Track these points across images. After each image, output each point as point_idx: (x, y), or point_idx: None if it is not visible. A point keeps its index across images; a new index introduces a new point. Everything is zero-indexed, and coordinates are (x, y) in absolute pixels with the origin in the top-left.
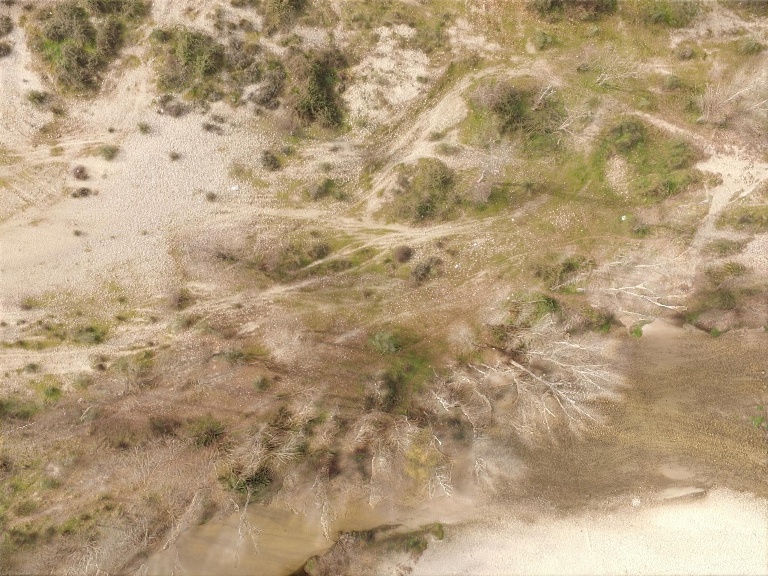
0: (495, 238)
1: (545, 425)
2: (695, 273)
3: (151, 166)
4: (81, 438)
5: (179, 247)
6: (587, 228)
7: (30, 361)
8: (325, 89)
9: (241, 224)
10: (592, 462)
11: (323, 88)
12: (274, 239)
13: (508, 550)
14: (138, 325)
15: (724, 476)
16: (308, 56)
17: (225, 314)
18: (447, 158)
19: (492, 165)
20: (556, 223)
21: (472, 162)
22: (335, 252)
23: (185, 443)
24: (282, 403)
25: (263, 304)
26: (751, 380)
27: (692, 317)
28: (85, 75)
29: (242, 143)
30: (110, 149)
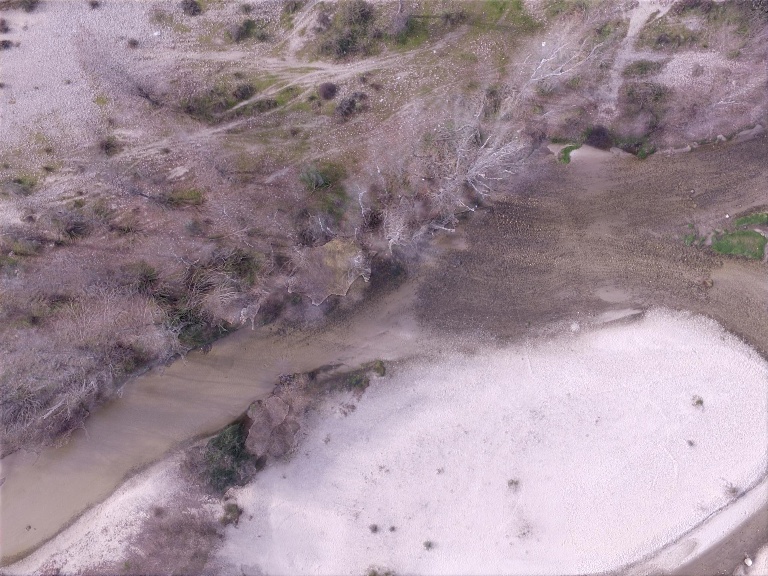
0: (418, 71)
1: (480, 256)
2: (618, 95)
3: (71, 15)
4: (14, 292)
5: (104, 95)
6: (508, 56)
7: None
8: None
9: (165, 69)
10: (529, 290)
11: None
12: (198, 82)
13: (450, 382)
14: (66, 175)
15: (661, 296)
16: None
17: (153, 160)
18: None
19: None
20: (477, 52)
21: None
22: (260, 92)
23: None
24: (215, 246)
25: (191, 148)
26: (681, 200)
27: (619, 140)
28: None
29: None
30: None
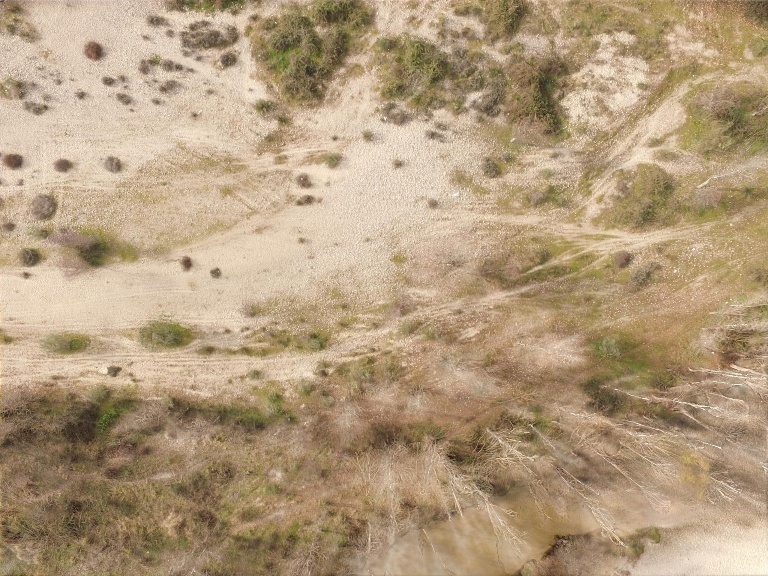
0: (713, 243)
1: None
2: None
3: (374, 173)
4: (303, 444)
5: (401, 254)
6: None
7: (253, 367)
8: (546, 96)
9: (462, 230)
10: None
11: (544, 95)
12: (495, 245)
13: (725, 553)
14: (360, 331)
15: None
16: (529, 63)
17: (446, 320)
18: (666, 164)
19: (711, 170)
20: None
21: (691, 168)
22: (555, 258)
23: (406, 448)
24: (502, 408)
25: (483, 310)
26: None
27: None
28: (311, 84)
29: (463, 150)
30: (335, 157)
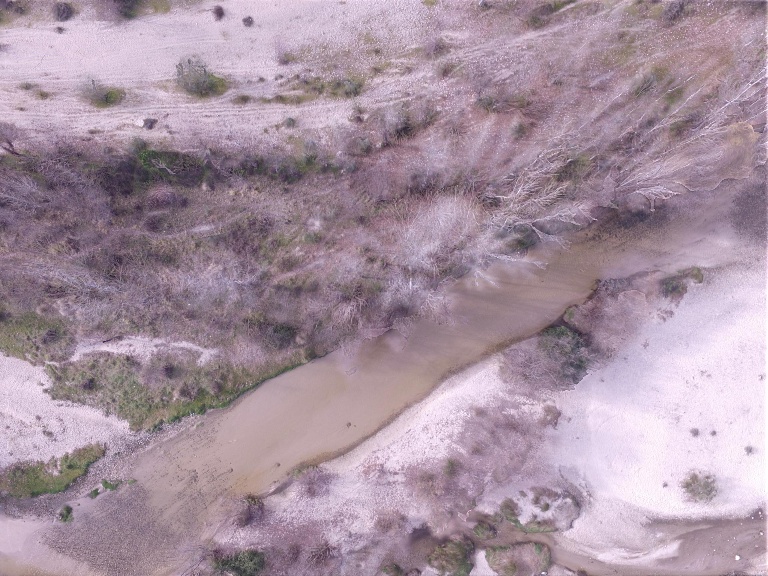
0: None
1: None
2: None
3: None
4: (340, 192)
5: None
6: None
7: (288, 116)
8: None
9: None
10: None
11: None
12: None
13: None
14: (394, 76)
15: None
16: None
17: (479, 62)
18: None
19: None
20: None
21: None
22: None
23: (444, 192)
24: (539, 149)
25: (517, 50)
26: None
27: None
28: None
29: None
30: None
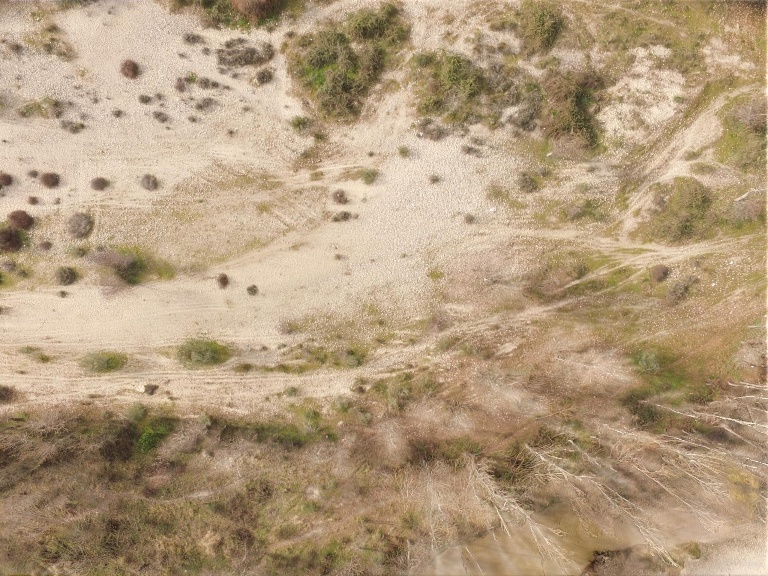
0: (751, 256)
1: None
2: None
3: (411, 189)
4: (340, 461)
5: (438, 269)
6: None
7: (290, 384)
8: (582, 110)
9: (499, 245)
10: None
11: (580, 109)
12: (532, 260)
13: (767, 569)
14: (397, 347)
15: None
16: (565, 78)
17: (483, 335)
18: (703, 177)
19: (748, 183)
20: None
21: (728, 181)
22: (592, 272)
23: (444, 465)
24: (540, 423)
25: (521, 325)
26: None
27: None
28: (348, 100)
29: (500, 165)
30: (372, 173)
